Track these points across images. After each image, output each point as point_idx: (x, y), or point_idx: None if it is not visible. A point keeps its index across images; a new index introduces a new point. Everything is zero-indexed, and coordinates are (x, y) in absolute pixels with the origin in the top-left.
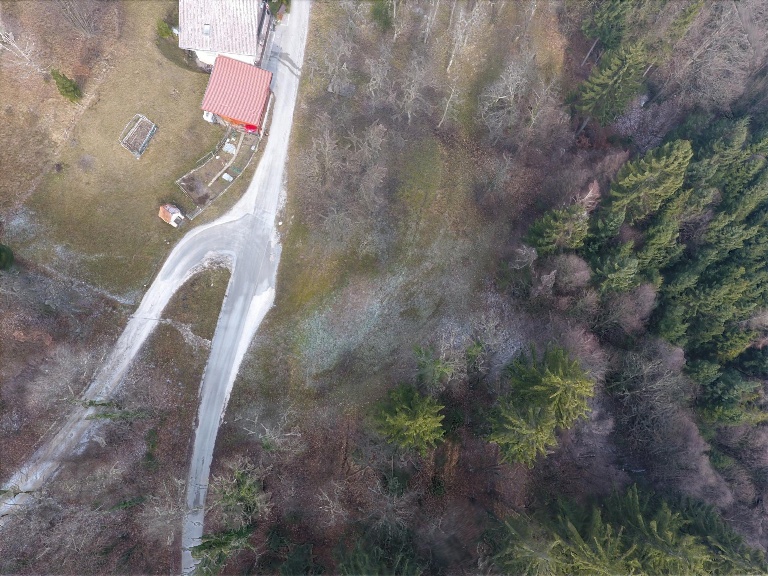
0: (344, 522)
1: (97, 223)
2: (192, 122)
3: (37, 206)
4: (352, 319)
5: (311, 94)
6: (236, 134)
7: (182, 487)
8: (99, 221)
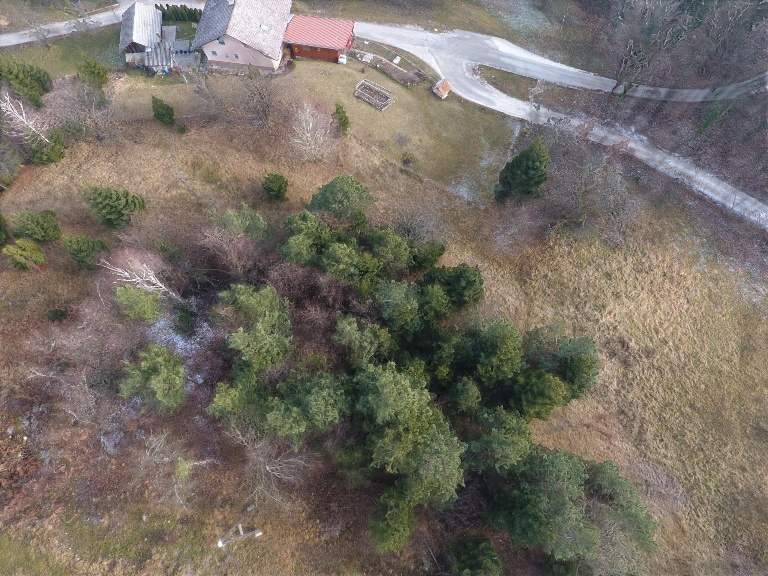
0: (634, 40)
1: (456, 138)
2: (350, 69)
3: (446, 179)
4: (505, 2)
5: (305, 8)
6: (353, 53)
7: (644, 101)
8: (454, 137)
